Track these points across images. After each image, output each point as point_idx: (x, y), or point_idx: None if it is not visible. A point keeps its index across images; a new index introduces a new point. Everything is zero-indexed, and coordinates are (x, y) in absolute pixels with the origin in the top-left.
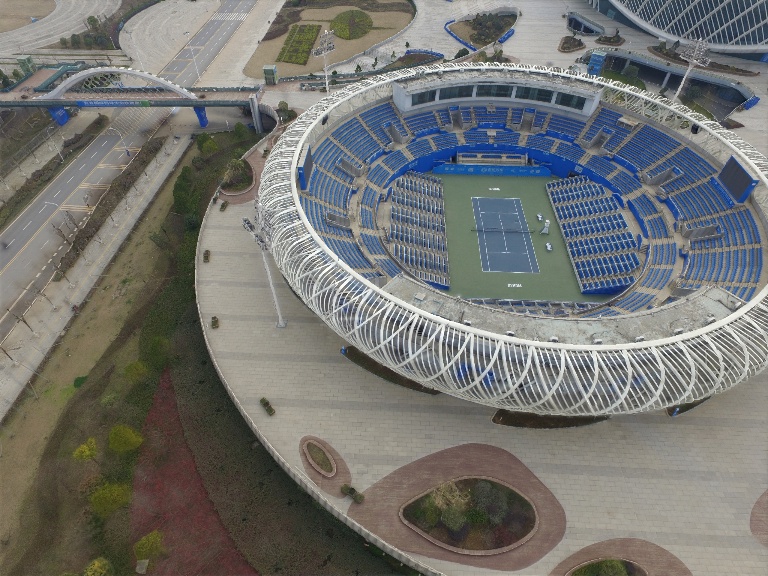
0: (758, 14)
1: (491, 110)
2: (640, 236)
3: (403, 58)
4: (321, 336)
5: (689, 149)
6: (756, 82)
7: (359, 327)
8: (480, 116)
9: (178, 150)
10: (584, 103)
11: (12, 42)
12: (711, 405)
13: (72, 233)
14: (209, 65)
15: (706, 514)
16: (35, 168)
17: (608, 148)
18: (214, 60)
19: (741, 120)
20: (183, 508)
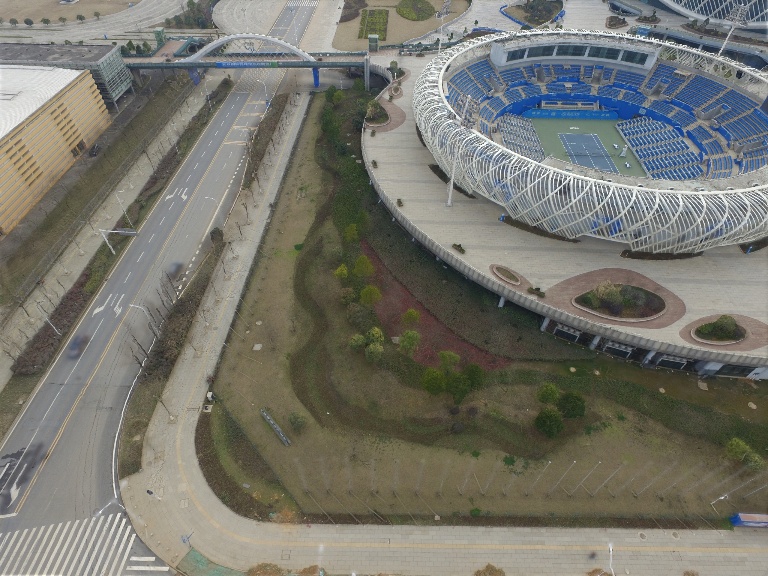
0: None
1: (567, 67)
2: (701, 153)
3: (471, 34)
4: (481, 211)
5: (734, 91)
6: None
7: (531, 185)
8: (558, 72)
9: (302, 103)
10: (646, 59)
11: (120, 23)
12: None
13: (242, 159)
14: (300, 41)
15: None
16: (189, 115)
17: (666, 94)
18: (303, 37)
19: None
20: None
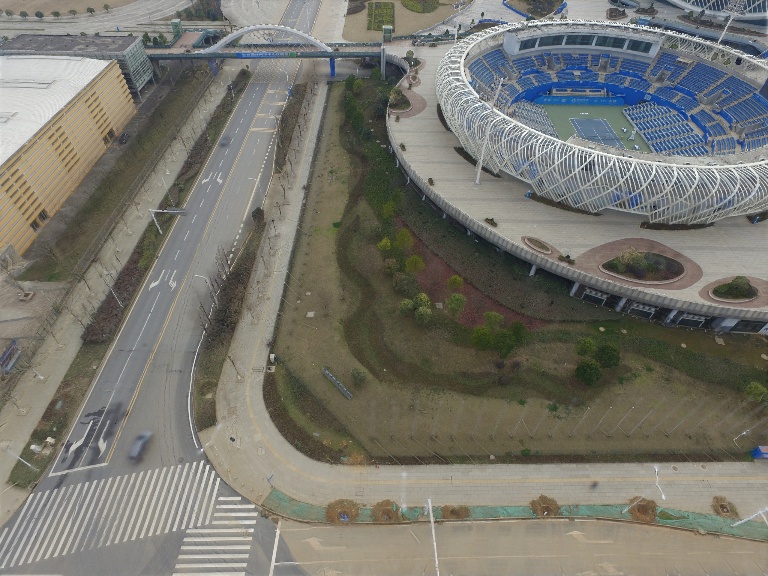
0: None
1: (575, 56)
2: (706, 135)
3: (477, 26)
4: (508, 189)
5: (734, 77)
6: (767, 40)
7: (559, 162)
8: (567, 61)
9: (321, 92)
10: (650, 47)
11: (130, 15)
12: None
13: (270, 145)
14: (310, 33)
15: None
16: (212, 104)
17: (670, 81)
18: (313, 29)
19: None
20: None
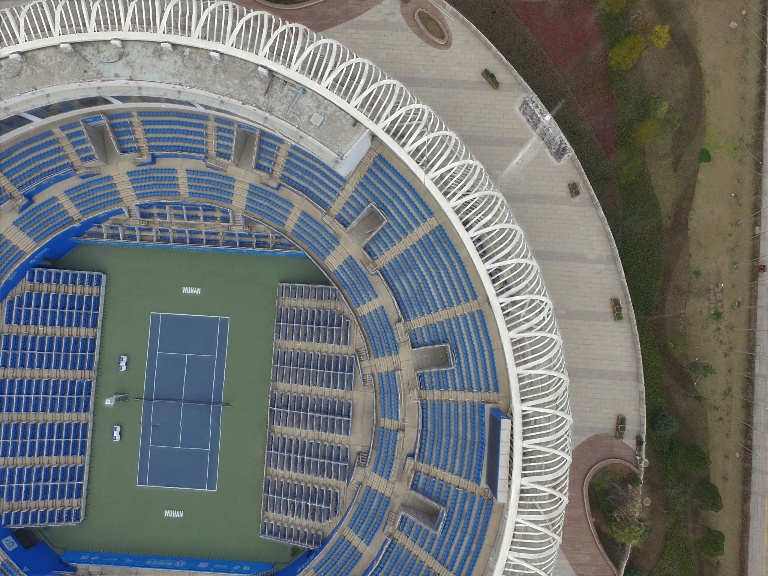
0: None
1: None
2: None
3: None
4: None
5: None
6: None
7: None
8: None
9: None
10: None
11: None
12: None
13: None
14: None
15: None
16: None
17: None
18: None
19: None
20: (551, 19)
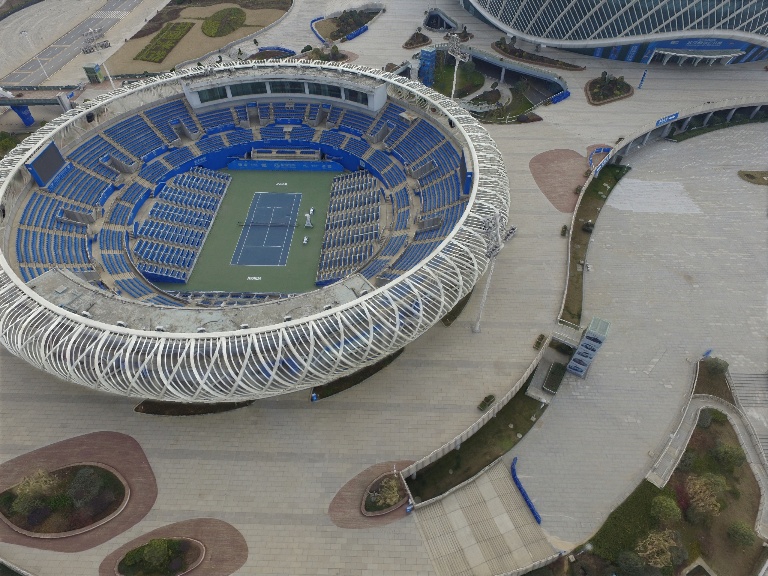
0: (579, 10)
1: (289, 106)
2: None
3: (255, 55)
4: None
5: (449, 143)
6: (579, 76)
7: None
8: (279, 112)
9: None
10: (367, 98)
11: None
12: (357, 390)
13: None
14: (66, 64)
15: (294, 494)
16: None
17: (389, 142)
18: (74, 59)
19: (543, 114)
20: None
